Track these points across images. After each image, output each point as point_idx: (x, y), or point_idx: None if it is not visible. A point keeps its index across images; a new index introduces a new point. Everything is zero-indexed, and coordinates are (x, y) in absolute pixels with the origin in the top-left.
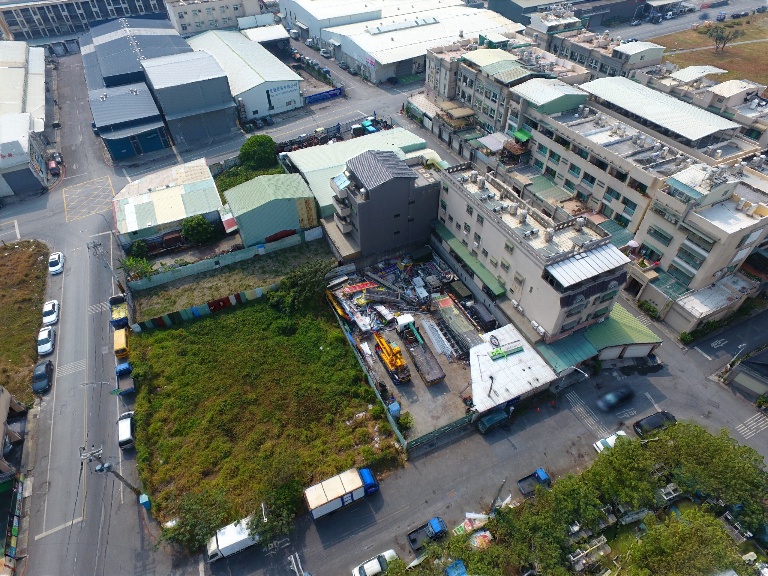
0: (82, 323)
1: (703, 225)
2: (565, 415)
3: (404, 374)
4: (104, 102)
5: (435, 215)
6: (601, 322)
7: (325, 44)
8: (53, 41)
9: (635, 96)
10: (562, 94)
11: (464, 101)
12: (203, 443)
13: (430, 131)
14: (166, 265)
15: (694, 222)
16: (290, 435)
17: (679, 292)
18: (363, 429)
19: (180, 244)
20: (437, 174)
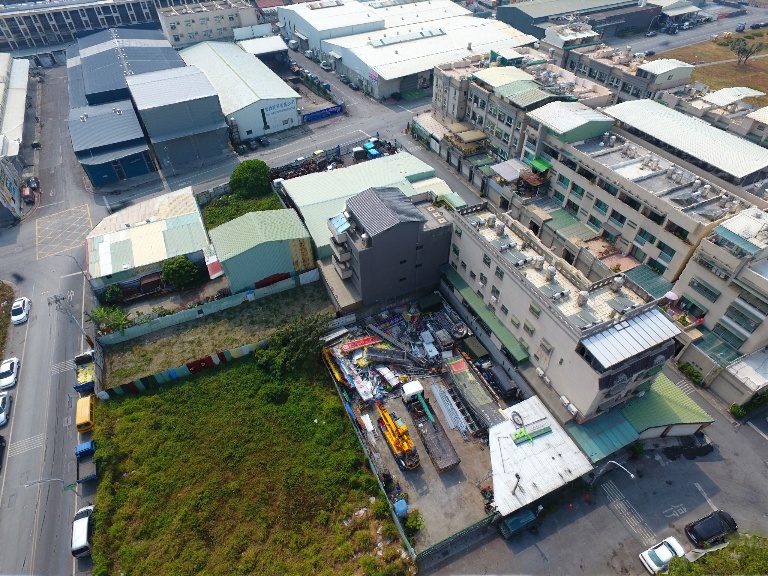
0: (43, 386)
1: (761, 284)
2: (602, 513)
3: (412, 461)
4: (84, 123)
5: (446, 259)
6: (641, 396)
7: (325, 56)
8: (39, 52)
9: (667, 123)
10: (586, 121)
11: (475, 123)
12: (173, 550)
13: (437, 154)
14: (142, 315)
15: (749, 280)
16: (277, 540)
17: (728, 357)
18: (364, 533)
19: (160, 288)
20: (448, 213)
